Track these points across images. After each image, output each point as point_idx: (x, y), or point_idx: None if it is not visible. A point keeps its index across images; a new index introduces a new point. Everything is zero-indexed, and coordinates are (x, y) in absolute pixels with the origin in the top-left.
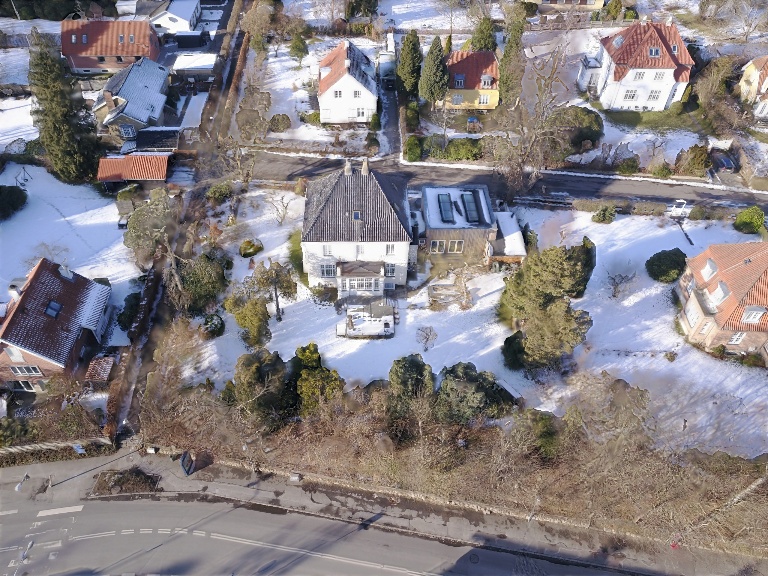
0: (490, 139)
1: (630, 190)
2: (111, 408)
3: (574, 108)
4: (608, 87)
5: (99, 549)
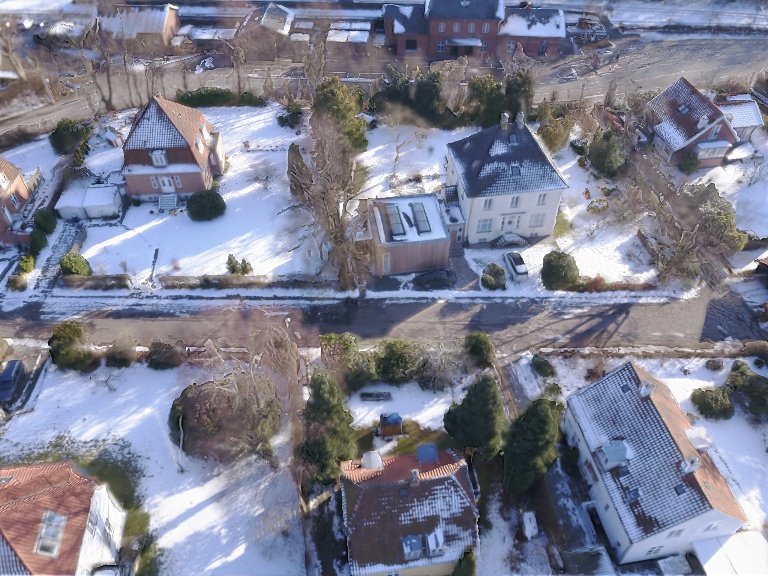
0: (367, 356)
1: (181, 326)
2: (604, 110)
3: (216, 416)
4: (111, 508)
5: (563, 88)
